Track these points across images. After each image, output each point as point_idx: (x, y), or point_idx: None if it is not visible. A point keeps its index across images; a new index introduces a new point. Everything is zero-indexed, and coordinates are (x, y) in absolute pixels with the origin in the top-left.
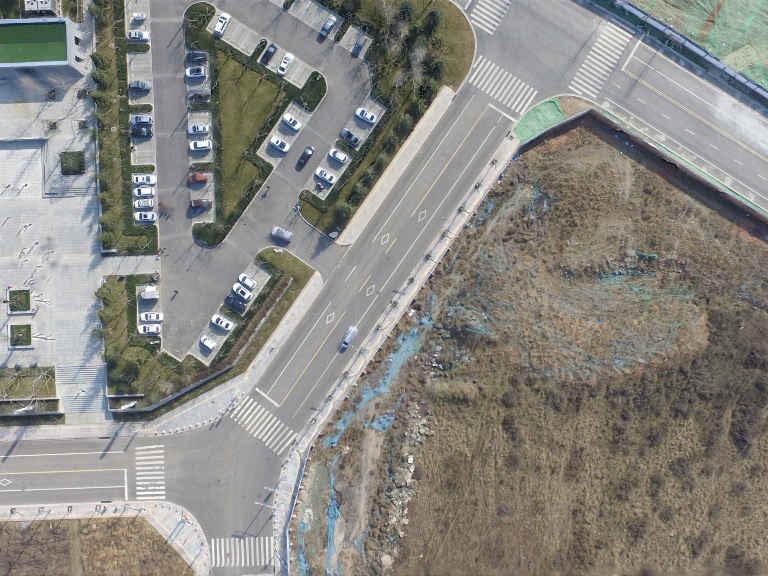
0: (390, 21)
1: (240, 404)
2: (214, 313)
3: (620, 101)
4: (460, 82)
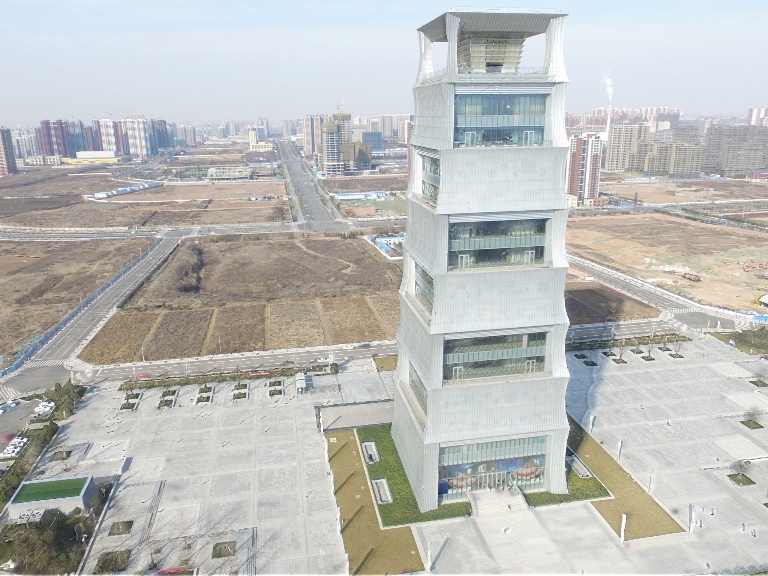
0: None
1: (13, 396)
2: (1, 415)
3: None
4: None
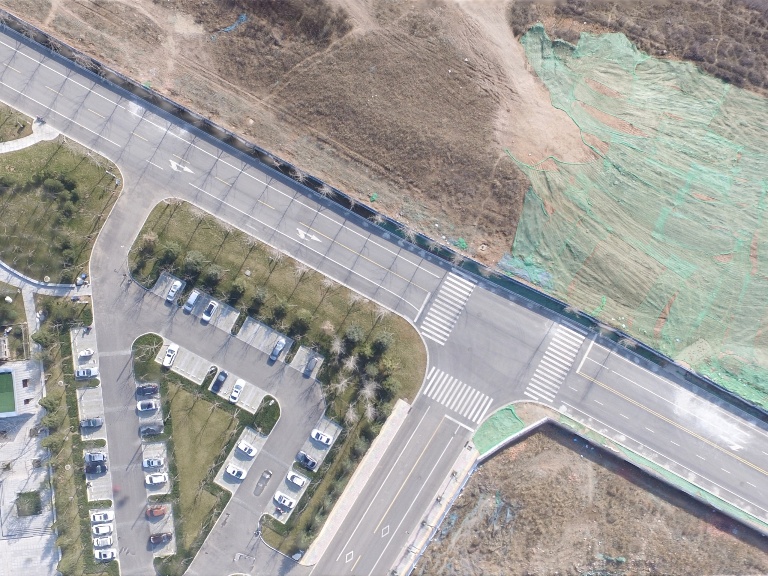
0: (340, 341)
1: None
2: None
3: (577, 404)
4: (415, 394)
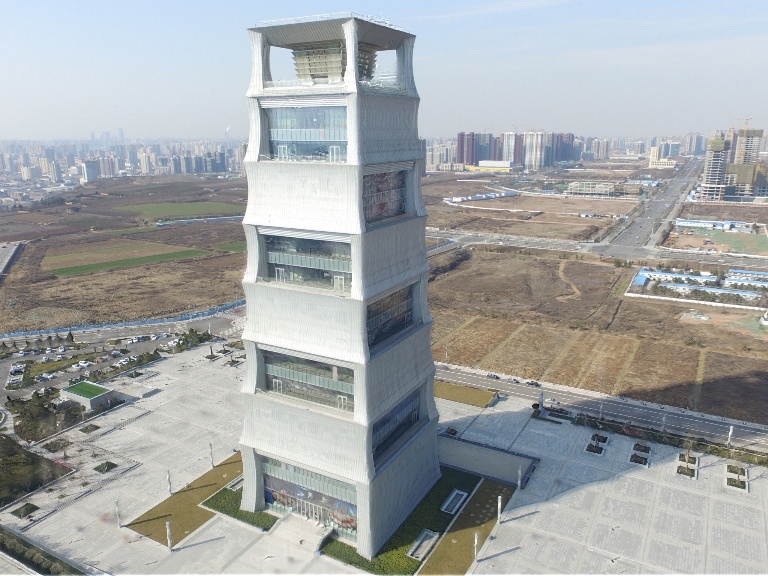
0: None
1: None
2: None
3: None
4: None
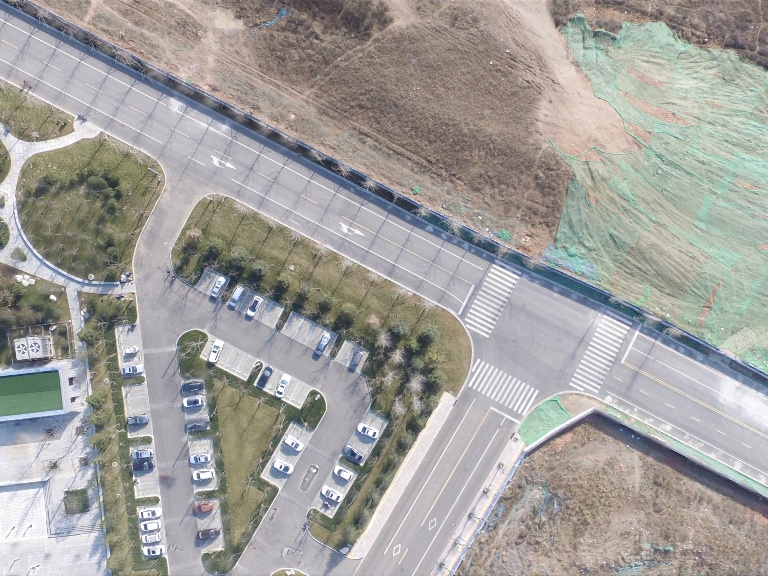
0: (385, 335)
1: None
2: None
3: (622, 394)
4: (460, 387)
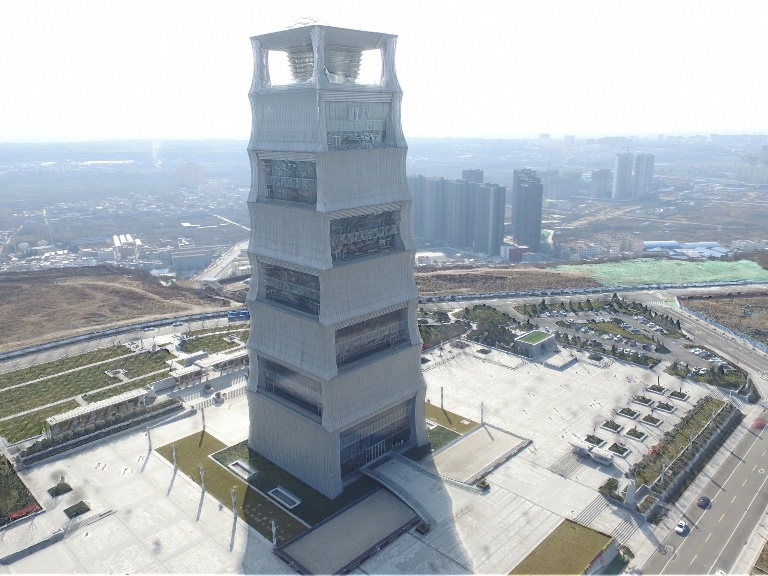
0: None
1: None
2: None
3: None
4: None
